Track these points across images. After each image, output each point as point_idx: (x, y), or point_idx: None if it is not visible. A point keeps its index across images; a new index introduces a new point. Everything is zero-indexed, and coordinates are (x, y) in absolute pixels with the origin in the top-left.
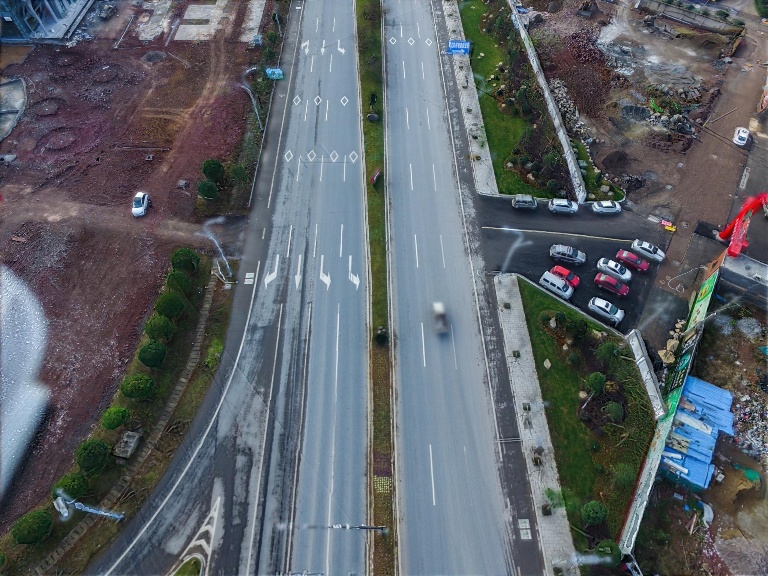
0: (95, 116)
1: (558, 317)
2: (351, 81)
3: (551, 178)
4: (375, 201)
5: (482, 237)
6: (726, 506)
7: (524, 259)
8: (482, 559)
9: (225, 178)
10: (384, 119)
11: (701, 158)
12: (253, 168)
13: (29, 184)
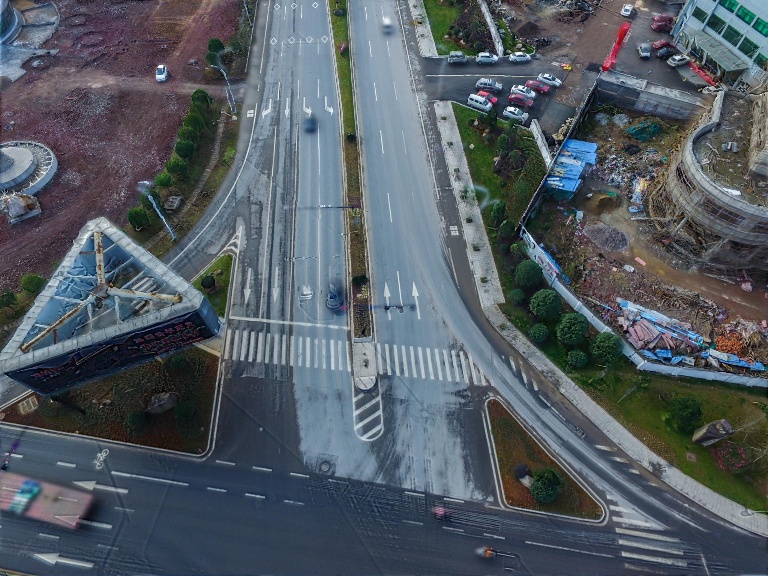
0: (117, 24)
1: (479, 117)
2: None
3: None
4: (343, 63)
5: (425, 81)
6: (593, 210)
7: (457, 92)
8: (425, 246)
9: (225, 56)
10: (348, 15)
11: (595, 25)
12: (246, 50)
13: (73, 67)
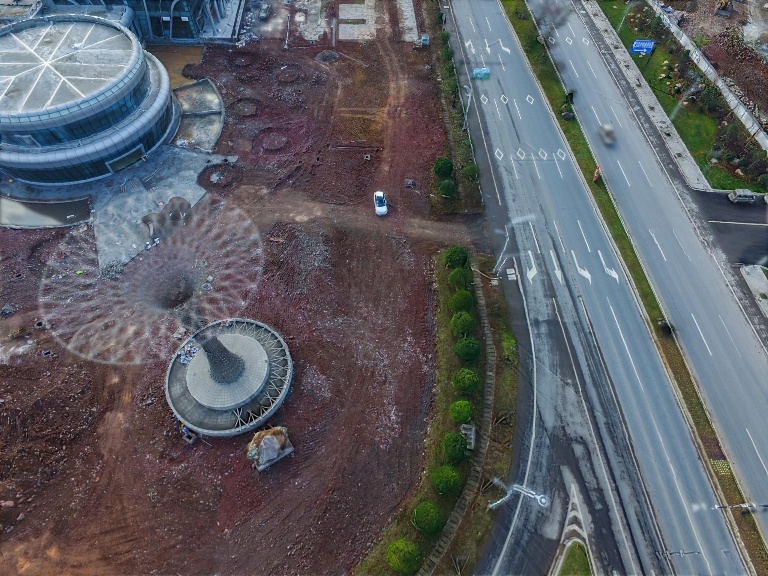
0: (297, 117)
1: None
2: (529, 80)
3: (759, 173)
4: (603, 197)
5: (713, 231)
6: None
7: (761, 251)
8: None
9: (451, 177)
10: (576, 117)
11: None
12: None
13: (263, 185)
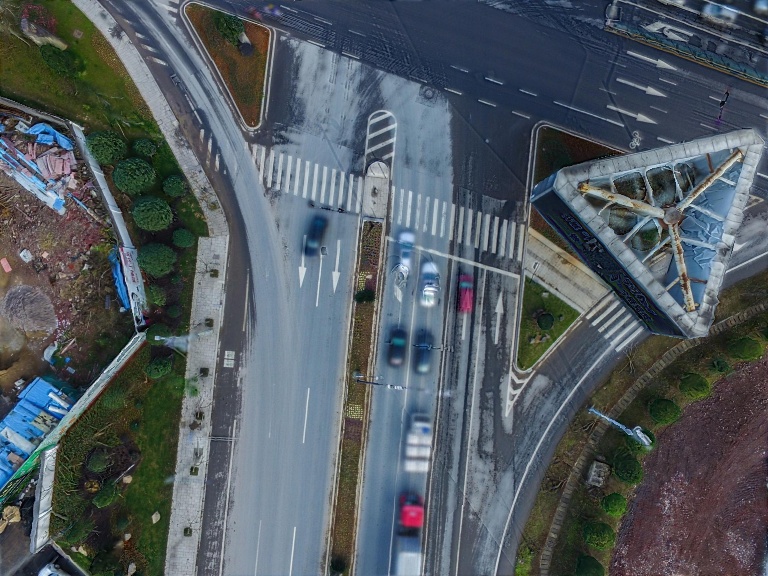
0: None
1: None
2: None
3: None
4: None
5: None
6: (27, 357)
7: None
8: (274, 341)
9: None
10: None
11: None
12: None
13: None
